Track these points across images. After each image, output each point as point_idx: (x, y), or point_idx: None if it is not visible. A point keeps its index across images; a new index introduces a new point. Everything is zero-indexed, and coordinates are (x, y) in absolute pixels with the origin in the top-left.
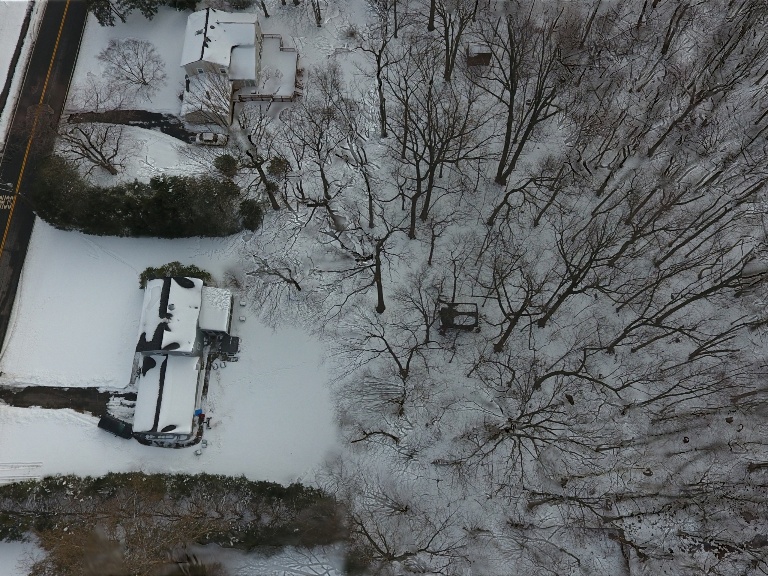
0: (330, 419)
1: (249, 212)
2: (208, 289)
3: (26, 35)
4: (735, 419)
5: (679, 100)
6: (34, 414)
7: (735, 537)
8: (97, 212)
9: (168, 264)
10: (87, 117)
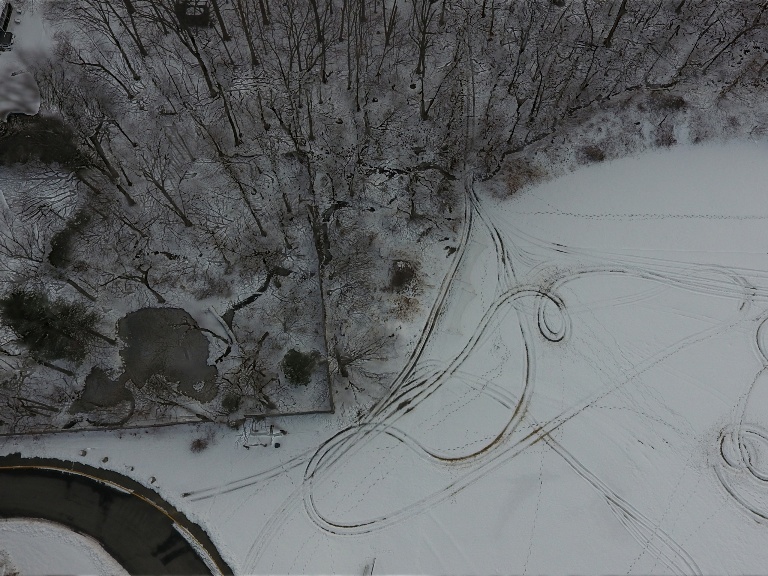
0: (43, 35)
1: None
2: None
3: None
4: (417, 85)
5: None
6: None
7: (404, 163)
8: None
9: None
10: None
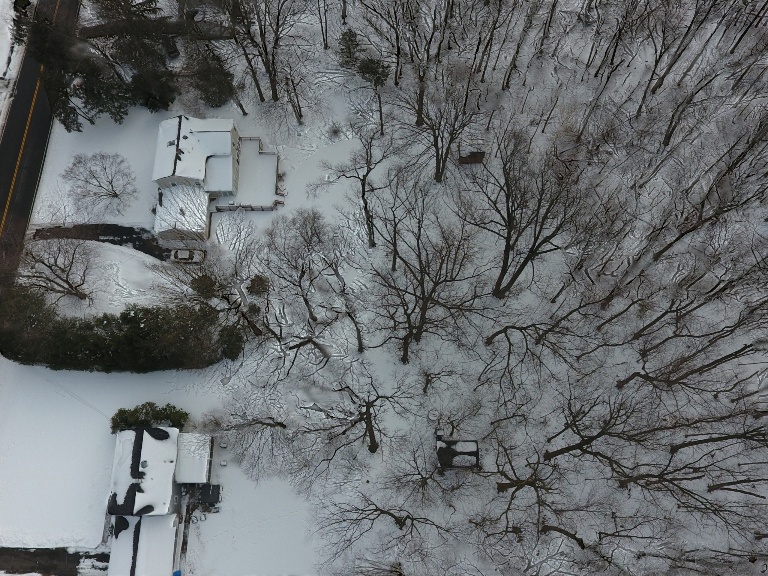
0: None
1: (228, 341)
2: (185, 436)
3: None
4: (758, 558)
5: None
6: None
7: None
8: (63, 352)
9: (141, 405)
10: (54, 232)
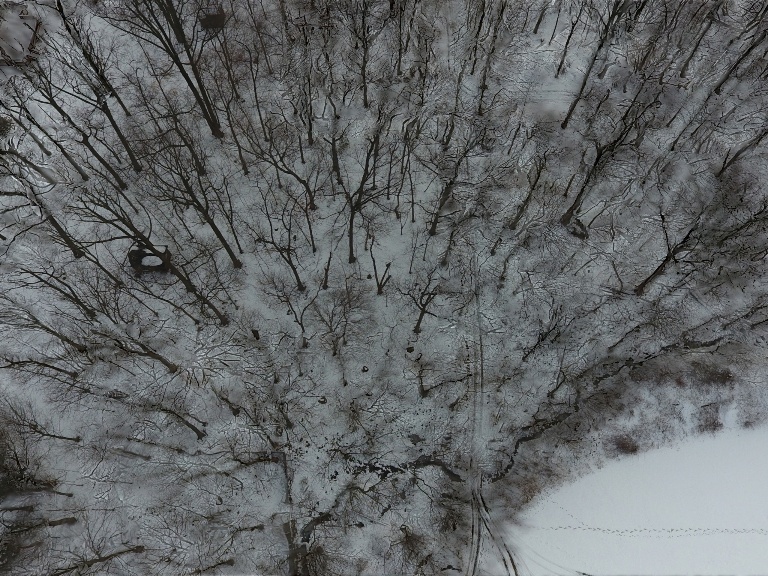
0: None
1: None
2: None
3: None
4: (415, 349)
5: (401, 54)
6: None
7: (399, 458)
8: None
9: None
10: None
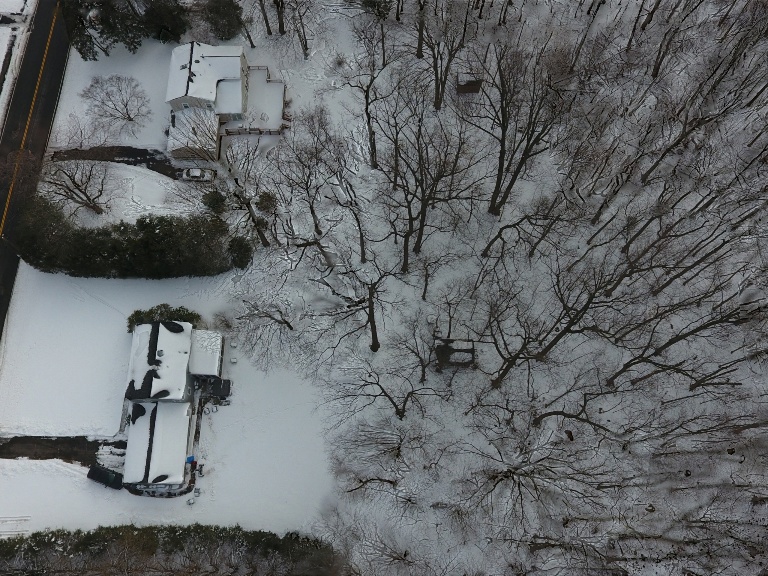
0: (325, 470)
1: (238, 250)
2: (198, 332)
3: (8, 71)
4: (737, 450)
5: (671, 124)
6: (21, 465)
7: (740, 573)
8: (82, 255)
9: (156, 306)
10: (71, 154)
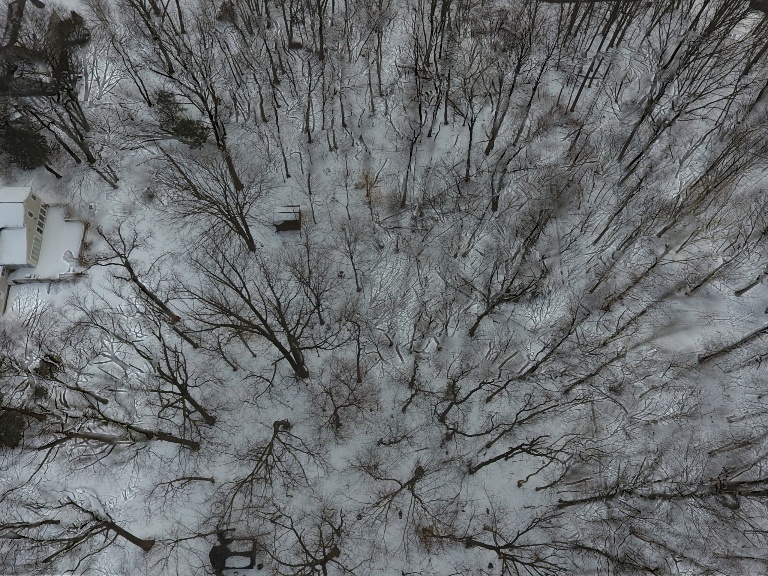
0: None
1: (5, 430)
2: None
3: None
4: None
5: (508, 266)
6: None
7: None
8: None
9: None
10: None
